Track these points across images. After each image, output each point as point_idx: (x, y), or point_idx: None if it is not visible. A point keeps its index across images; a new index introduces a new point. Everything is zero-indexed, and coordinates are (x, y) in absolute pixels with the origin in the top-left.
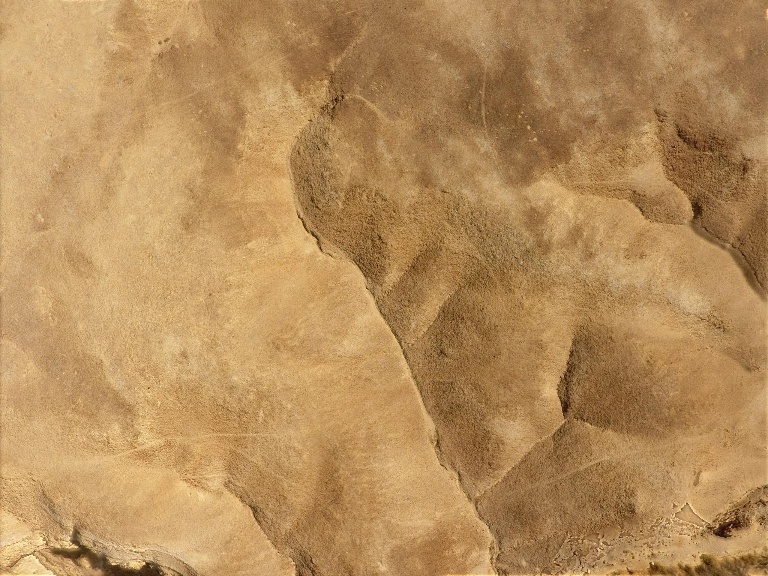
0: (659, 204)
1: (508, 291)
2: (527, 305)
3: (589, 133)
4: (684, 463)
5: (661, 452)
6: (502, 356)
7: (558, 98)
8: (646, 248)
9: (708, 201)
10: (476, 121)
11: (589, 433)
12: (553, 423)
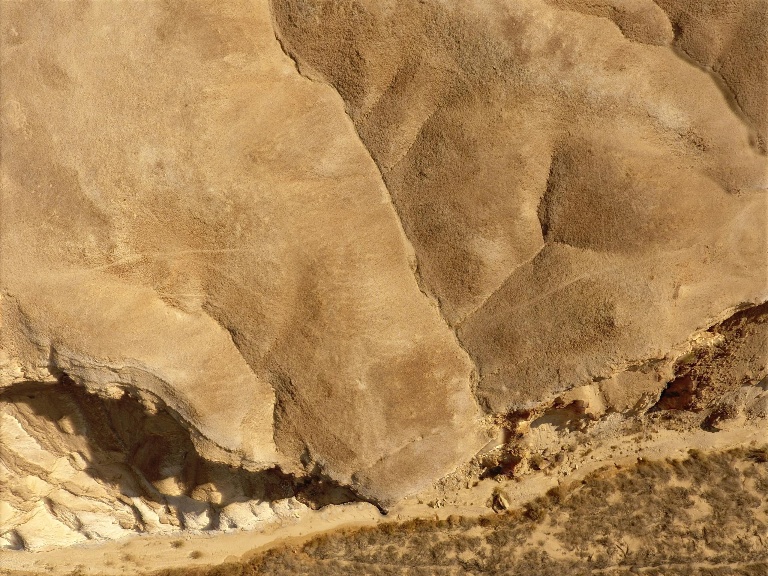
0: (639, 21)
1: (487, 104)
2: (506, 117)
3: None
4: (663, 277)
5: (641, 267)
6: (481, 172)
7: None
8: (625, 62)
9: (688, 22)
10: None
11: (569, 253)
12: (533, 246)
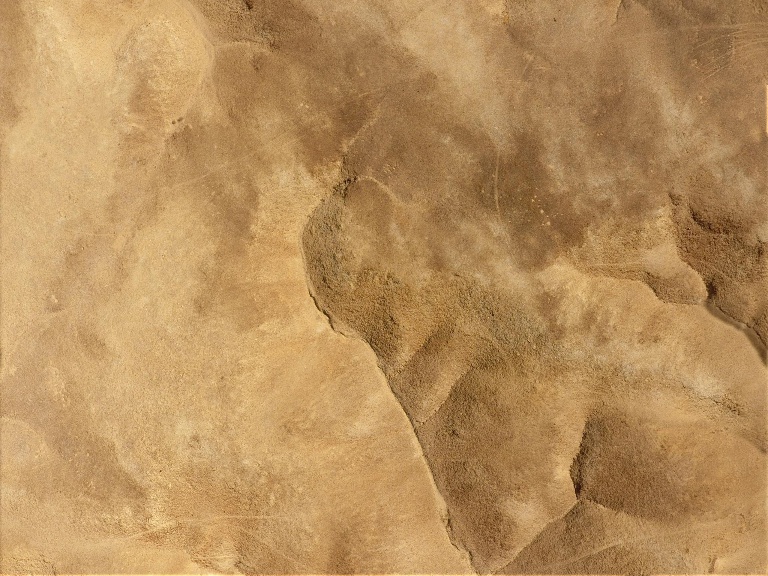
0: (673, 286)
1: (521, 374)
2: (540, 389)
3: (603, 217)
4: (699, 550)
5: (675, 538)
6: (514, 439)
7: (571, 182)
8: (660, 331)
9: (722, 281)
10: (489, 205)
11: (602, 516)
12: (566, 504)
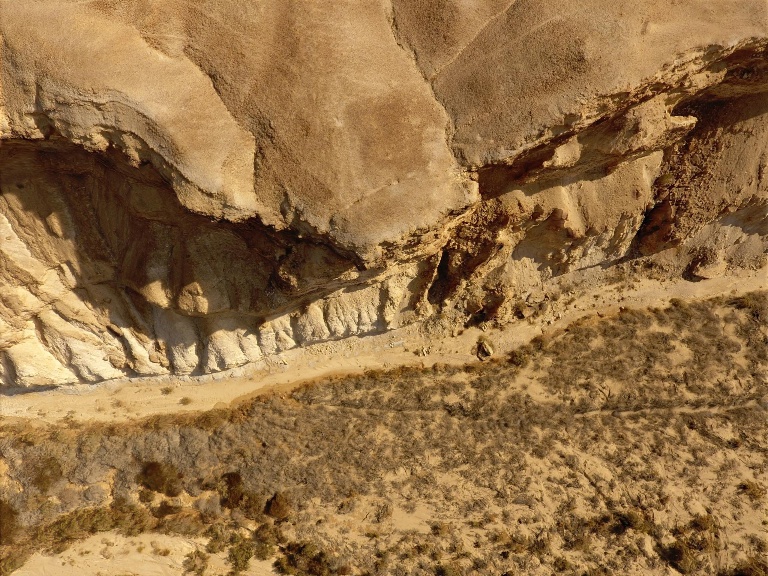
0: None
1: None
2: None
3: None
4: (632, 14)
5: (610, 5)
6: None
7: None
8: None
9: None
10: None
11: None
12: None
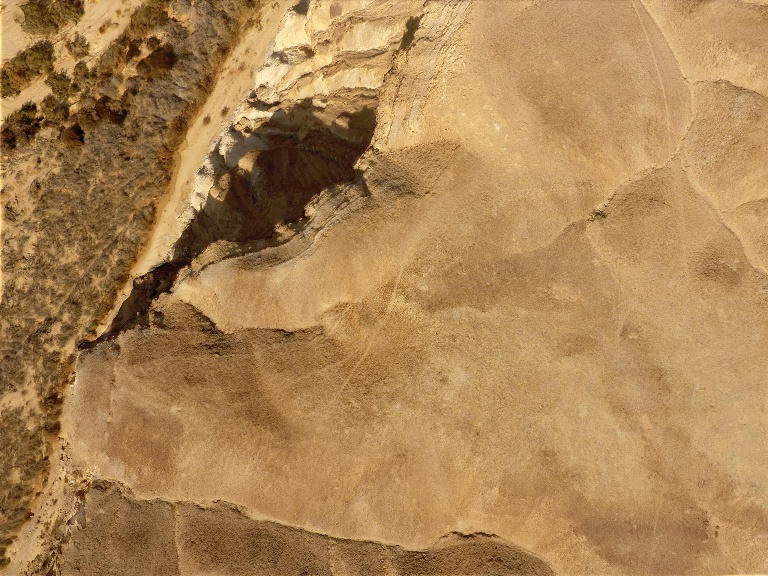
0: None
1: None
2: None
3: None
4: None
5: None
6: None
7: None
8: None
9: None
10: None
11: None
12: None
